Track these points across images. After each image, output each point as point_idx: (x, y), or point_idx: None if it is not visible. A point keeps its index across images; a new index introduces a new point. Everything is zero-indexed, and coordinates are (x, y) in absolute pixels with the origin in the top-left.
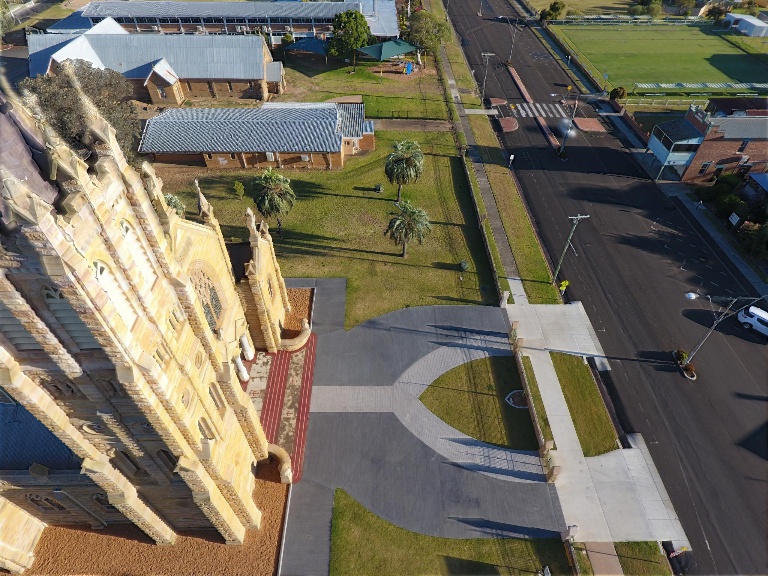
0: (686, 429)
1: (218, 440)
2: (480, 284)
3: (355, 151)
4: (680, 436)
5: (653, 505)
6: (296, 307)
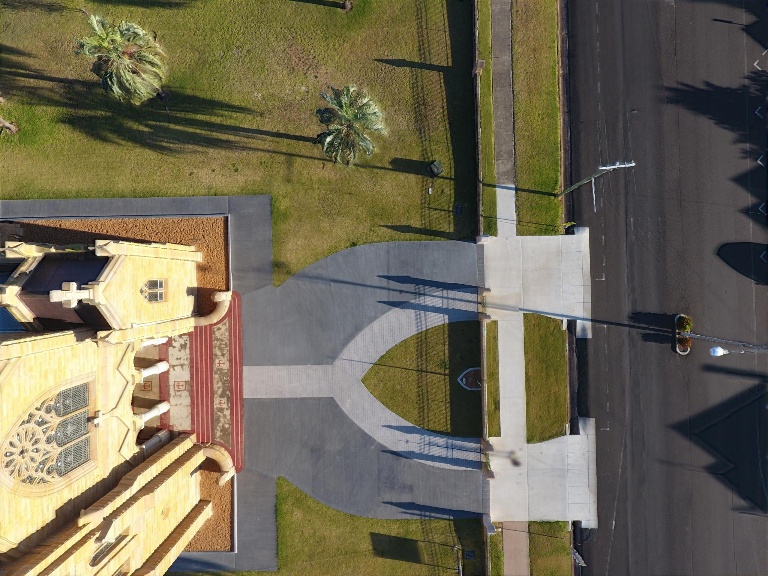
0: (646, 416)
1: (130, 554)
2: (455, 201)
3: None
4: (636, 423)
5: (578, 491)
6: (208, 251)
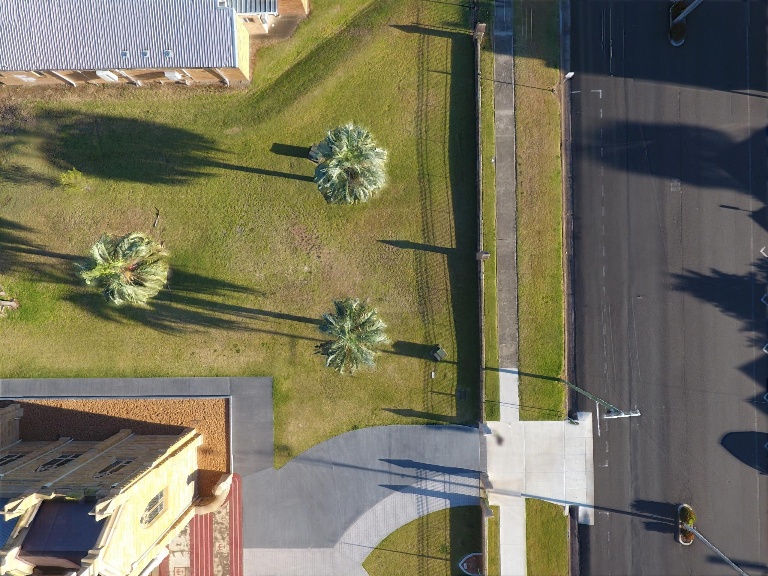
0: None
1: None
2: (458, 386)
3: (270, 21)
4: None
5: None
6: (209, 433)
